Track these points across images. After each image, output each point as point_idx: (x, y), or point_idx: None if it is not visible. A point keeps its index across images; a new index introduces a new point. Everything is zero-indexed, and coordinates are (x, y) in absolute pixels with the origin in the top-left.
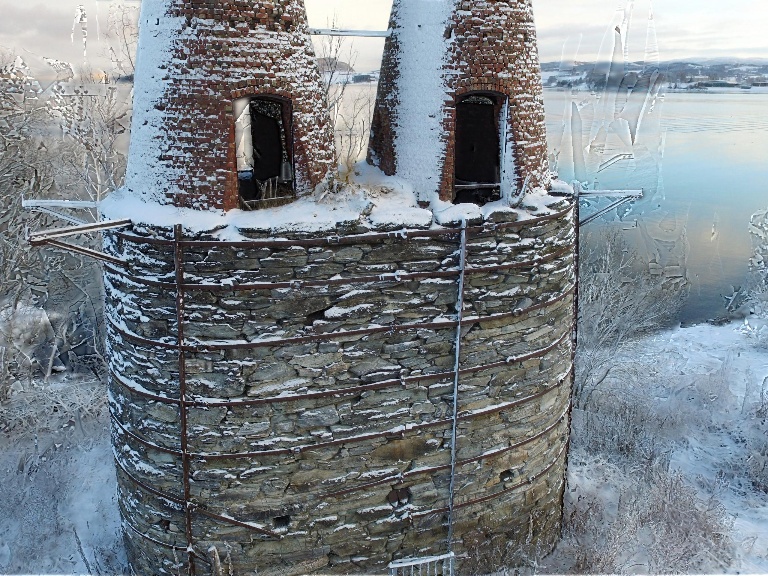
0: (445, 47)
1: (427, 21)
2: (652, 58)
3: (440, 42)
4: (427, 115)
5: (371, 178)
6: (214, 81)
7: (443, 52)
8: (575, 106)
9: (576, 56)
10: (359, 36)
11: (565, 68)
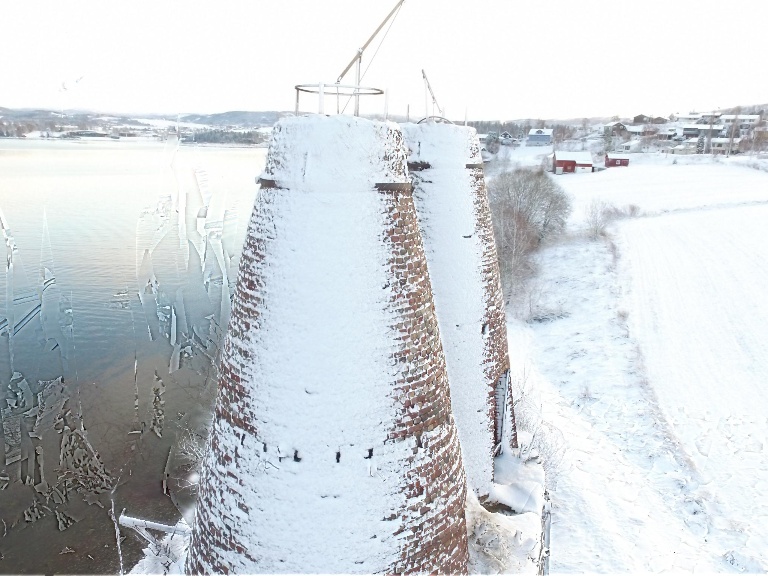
0: (484, 343)
1: (467, 321)
2: (204, 177)
3: (480, 339)
4: (476, 411)
5: None
6: (452, 505)
7: (483, 348)
8: (192, 244)
9: (223, 209)
10: None
11: (212, 220)
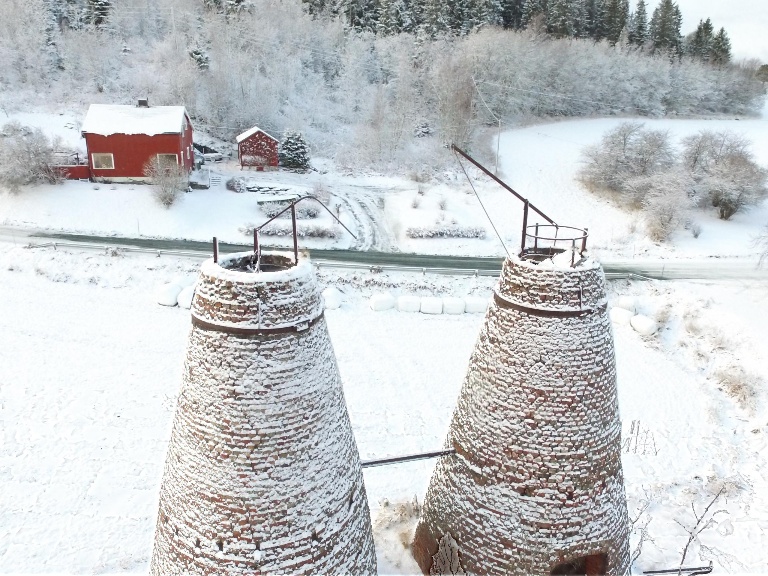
0: None
1: None
2: None
3: None
4: None
5: (380, 573)
6: None
7: None
8: None
9: None
10: (397, 461)
11: None
